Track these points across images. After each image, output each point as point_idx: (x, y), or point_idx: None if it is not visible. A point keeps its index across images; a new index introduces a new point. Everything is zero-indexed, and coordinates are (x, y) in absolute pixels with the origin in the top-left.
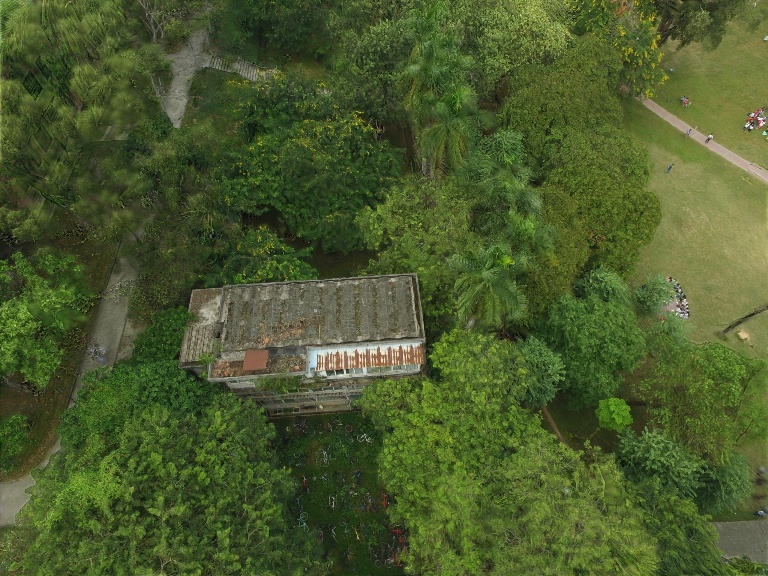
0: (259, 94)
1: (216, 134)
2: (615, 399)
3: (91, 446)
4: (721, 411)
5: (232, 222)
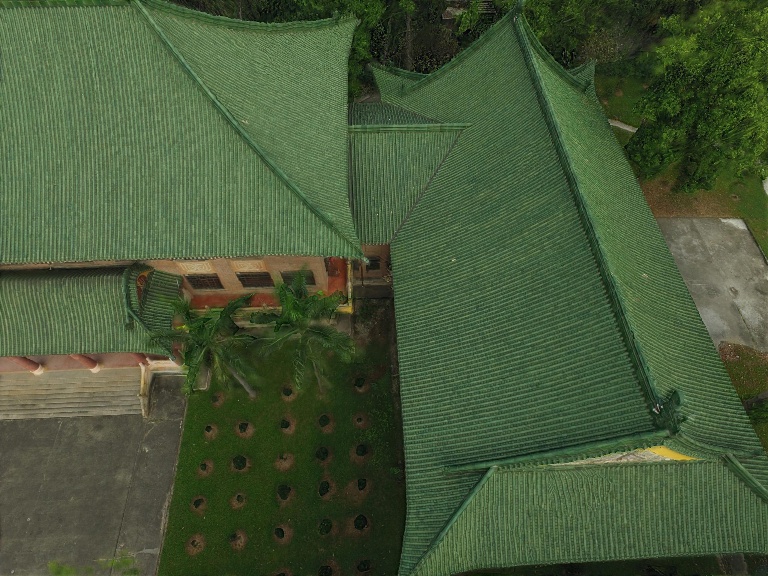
0: None
1: None
2: None
3: None
4: None
5: None
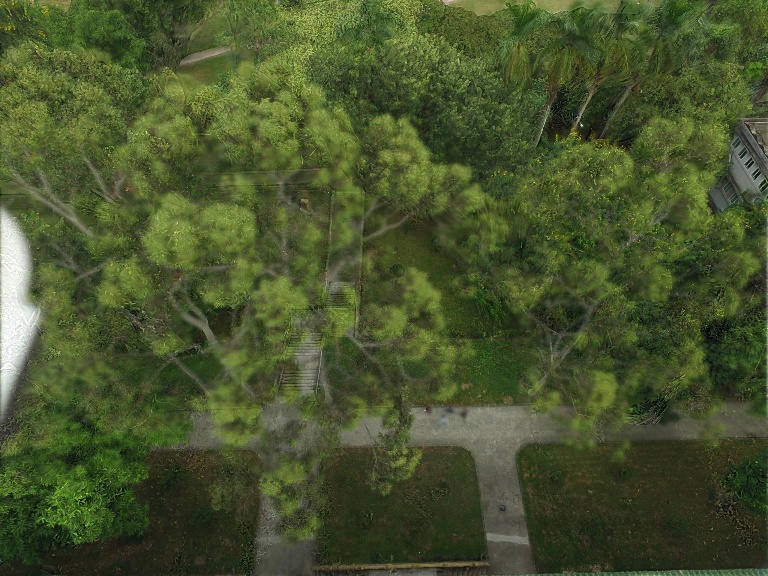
0: (549, 223)
1: (480, 360)
2: (753, 65)
3: None
4: (766, 18)
5: (761, 236)
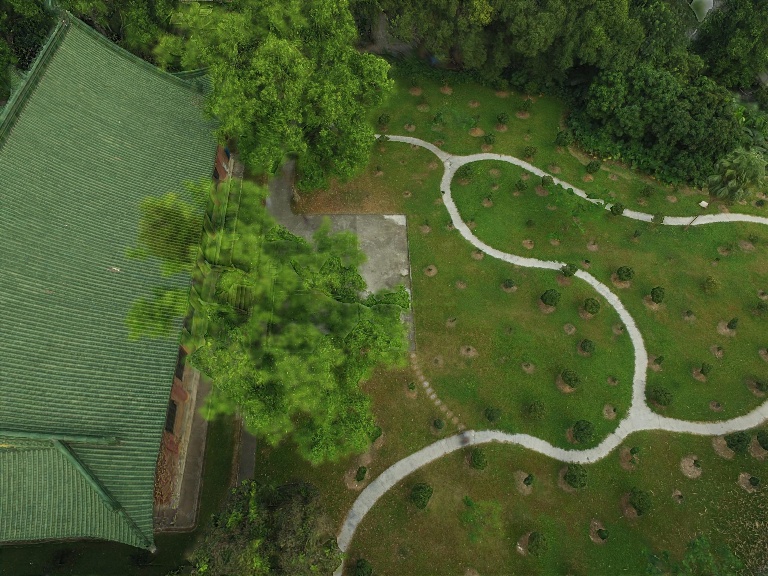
0: None
1: None
2: None
3: (266, 2)
4: None
5: None
